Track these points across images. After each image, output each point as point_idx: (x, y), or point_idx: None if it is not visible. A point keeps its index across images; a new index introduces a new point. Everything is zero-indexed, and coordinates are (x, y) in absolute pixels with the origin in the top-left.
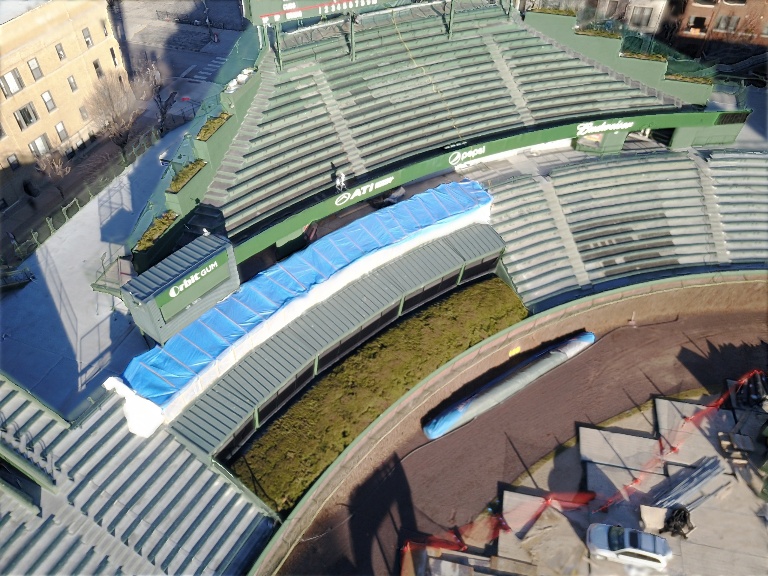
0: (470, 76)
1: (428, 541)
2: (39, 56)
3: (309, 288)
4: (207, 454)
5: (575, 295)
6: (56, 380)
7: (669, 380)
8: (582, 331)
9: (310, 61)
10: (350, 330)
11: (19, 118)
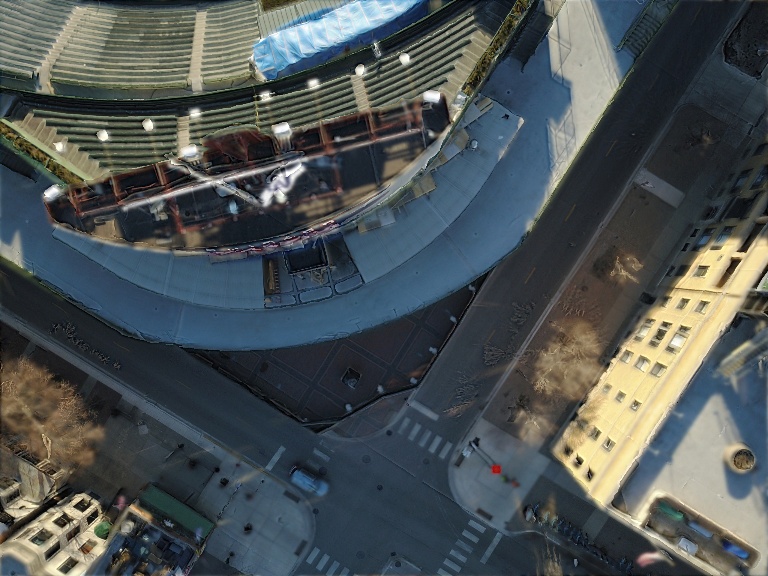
0: None
1: None
2: None
3: None
4: None
5: (213, 7)
6: None
7: None
8: None
9: None
10: None
11: None
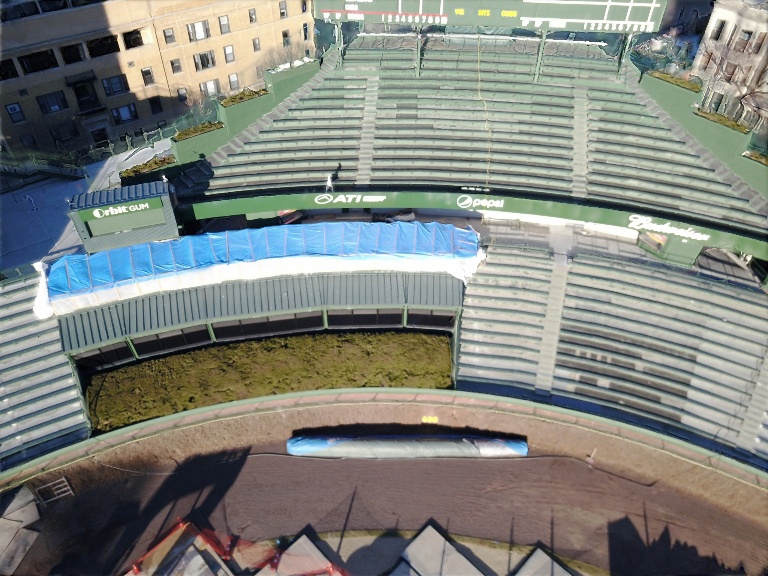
0: (535, 125)
1: (203, 531)
2: (231, 15)
3: (232, 261)
4: (63, 352)
5: (524, 394)
6: (32, 251)
7: (575, 540)
8: (521, 438)
9: (373, 66)
10: (251, 314)
11: (198, 60)
